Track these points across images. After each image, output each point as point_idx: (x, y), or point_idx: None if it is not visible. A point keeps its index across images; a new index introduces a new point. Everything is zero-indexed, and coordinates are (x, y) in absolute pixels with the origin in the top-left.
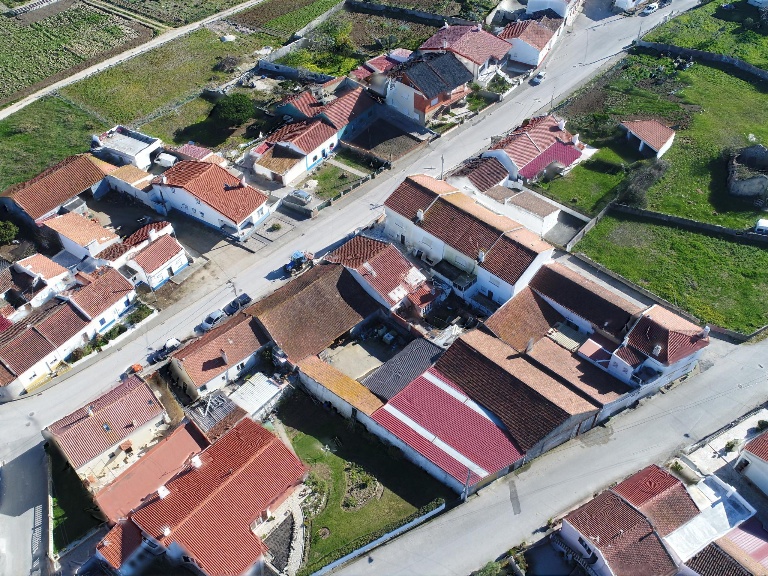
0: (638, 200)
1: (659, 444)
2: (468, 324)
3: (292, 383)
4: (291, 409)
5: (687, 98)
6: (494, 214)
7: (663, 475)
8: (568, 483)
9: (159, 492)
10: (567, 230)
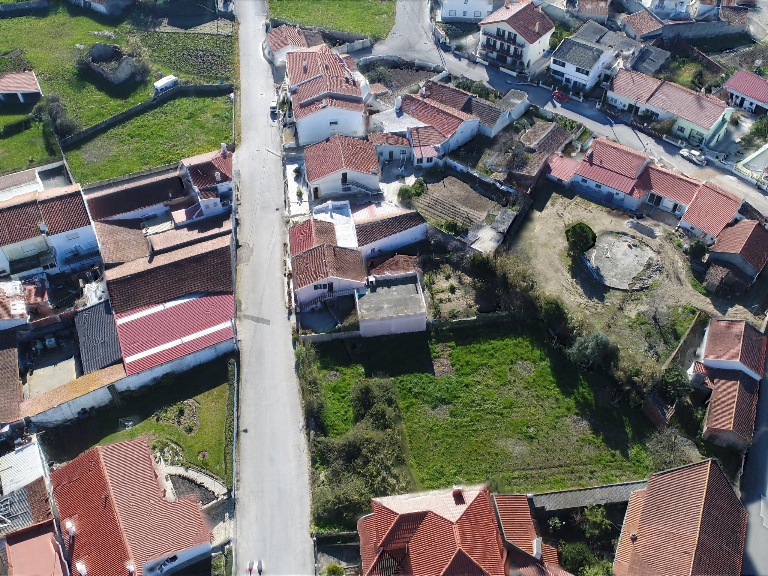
0: (74, 127)
1: (273, 225)
2: (92, 278)
3: (37, 433)
4: (60, 449)
5: (2, 50)
6: (5, 201)
7: (301, 226)
8: (267, 285)
9: (80, 570)
10: (56, 181)
